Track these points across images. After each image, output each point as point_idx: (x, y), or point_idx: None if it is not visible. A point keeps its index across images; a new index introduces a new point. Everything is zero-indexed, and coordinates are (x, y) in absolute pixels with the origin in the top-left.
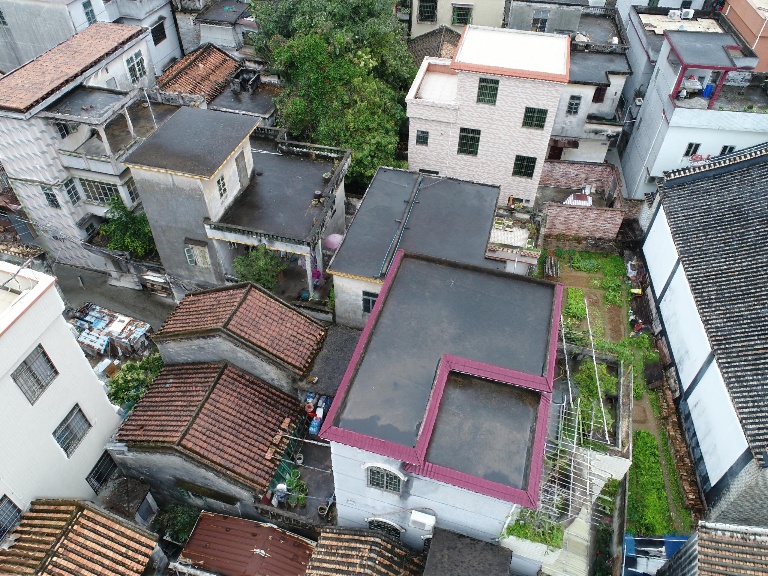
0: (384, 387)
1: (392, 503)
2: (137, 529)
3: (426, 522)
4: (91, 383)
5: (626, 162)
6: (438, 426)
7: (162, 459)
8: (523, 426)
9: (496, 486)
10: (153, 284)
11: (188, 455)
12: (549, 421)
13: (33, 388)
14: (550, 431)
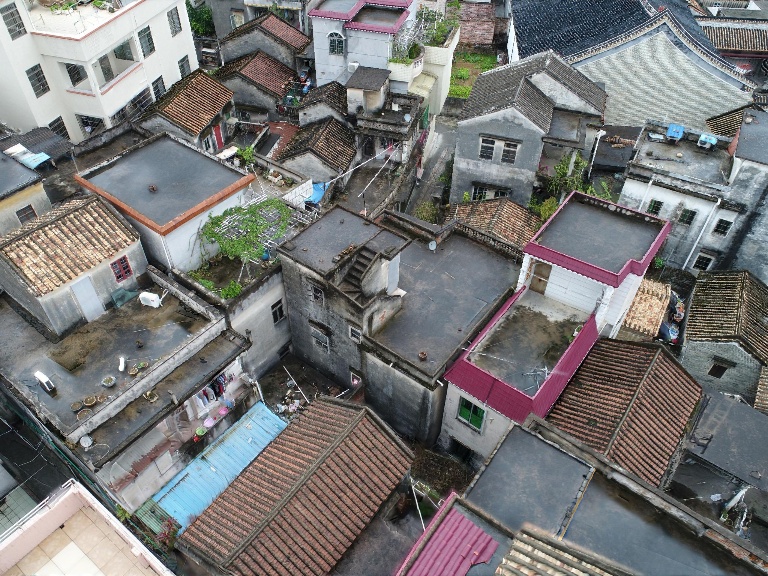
0: (336, 5)
1: (341, 65)
2: None
3: (355, 65)
4: (193, 49)
5: (505, 7)
6: (359, 19)
7: (229, 85)
8: (395, 19)
9: (380, 27)
10: (207, 57)
11: (244, 75)
12: (409, 24)
13: (173, 28)
14: (409, 26)
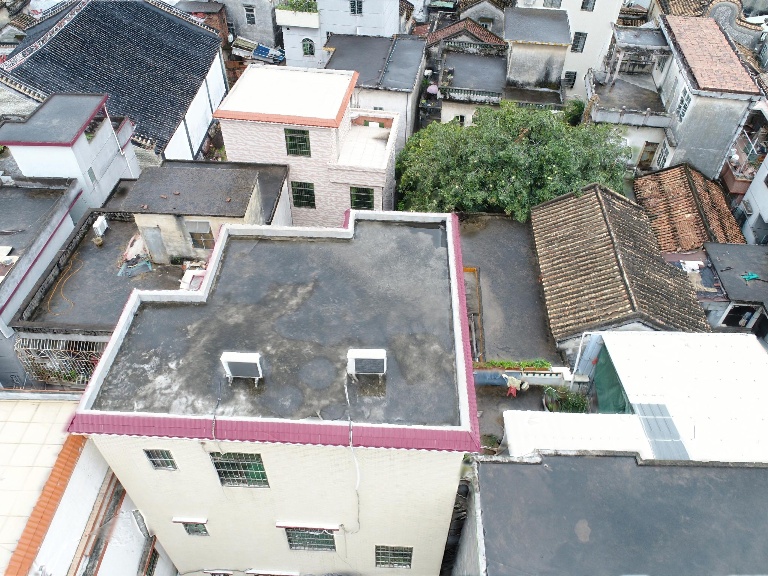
0: None
1: None
2: (467, 7)
3: None
4: None
5: None
6: None
7: None
8: None
9: None
10: None
11: None
12: None
13: None
14: None
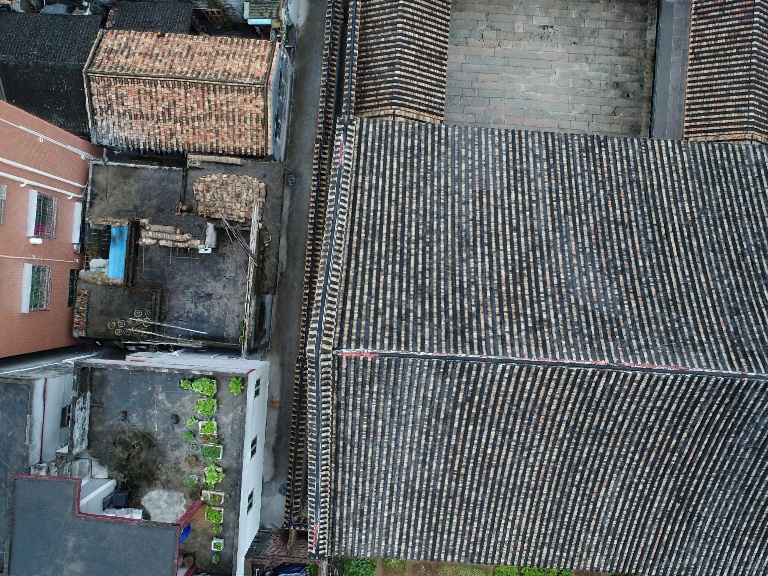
0: None
1: None
2: None
3: None
4: None
5: None
6: None
7: None
8: None
9: None
10: None
11: None
12: None
13: None
14: None
